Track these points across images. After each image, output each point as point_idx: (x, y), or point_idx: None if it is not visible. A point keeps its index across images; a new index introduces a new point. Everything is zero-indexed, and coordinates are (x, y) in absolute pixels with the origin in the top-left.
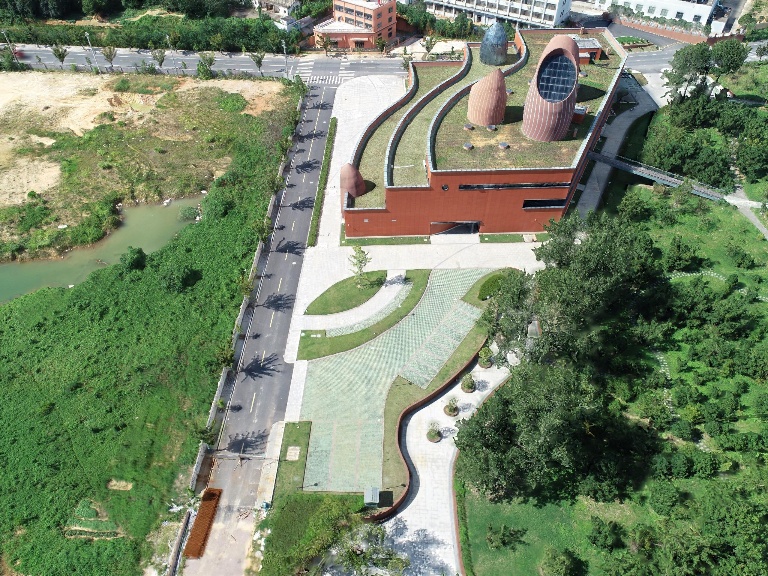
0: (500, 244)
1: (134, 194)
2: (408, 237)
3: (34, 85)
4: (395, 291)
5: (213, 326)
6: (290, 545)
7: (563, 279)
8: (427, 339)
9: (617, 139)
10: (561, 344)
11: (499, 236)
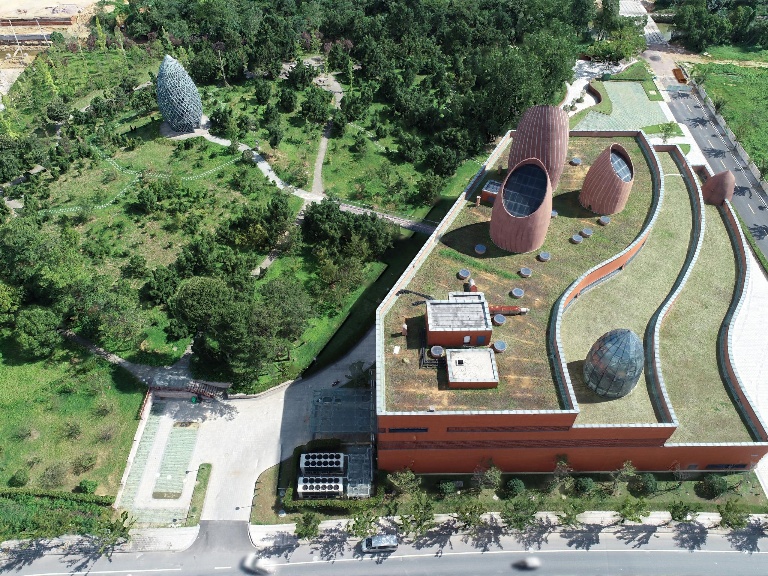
0: None
1: None
2: None
3: None
4: None
5: None
6: None
7: None
8: None
9: None
10: None
11: None
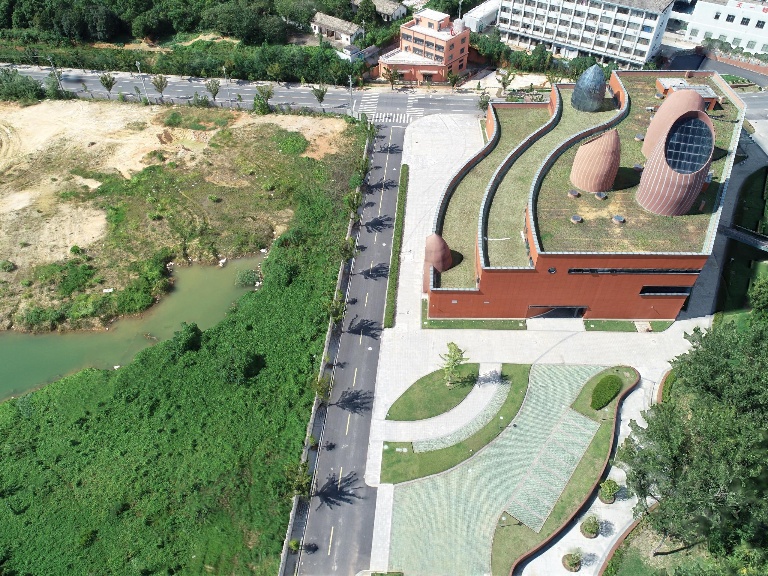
0: (609, 333)
1: (186, 251)
2: (500, 320)
3: (79, 116)
4: (491, 392)
5: (280, 431)
6: None
7: (737, 428)
8: (534, 461)
9: (729, 200)
10: (724, 502)
11: (607, 323)
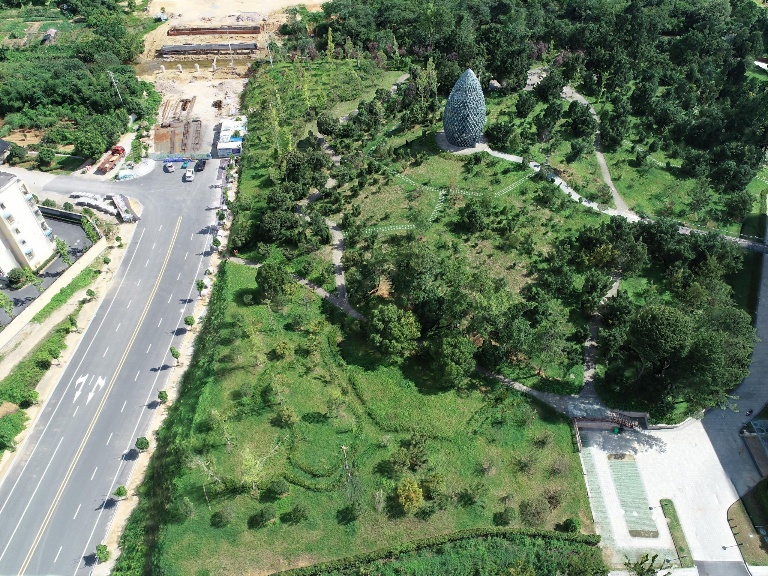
0: None
1: None
2: None
3: None
4: None
5: None
6: None
7: None
8: None
9: (762, 341)
10: None
11: None
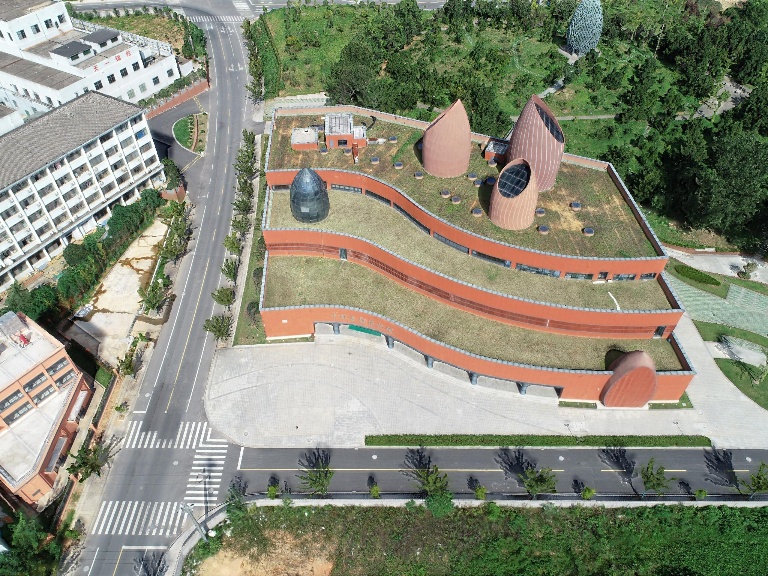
0: None
1: None
2: None
3: None
4: (744, 350)
5: None
6: None
7: None
8: None
9: None
10: None
11: None
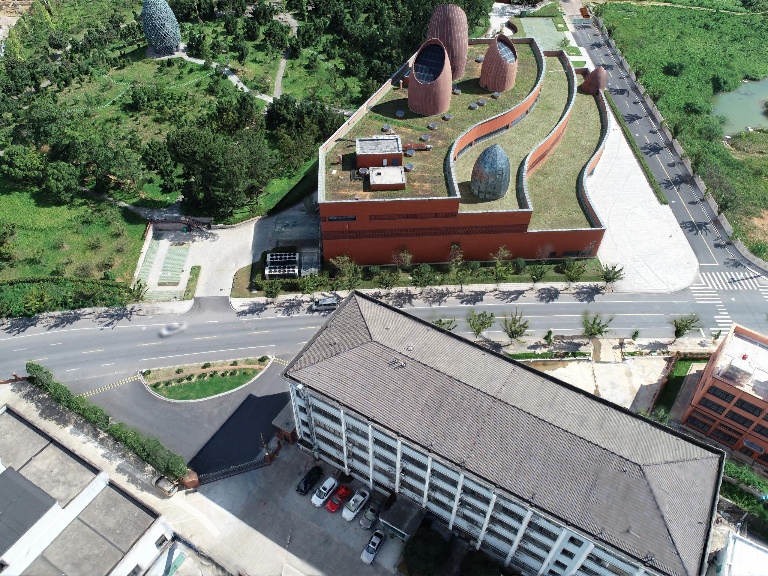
0: None
1: None
2: None
3: None
4: None
5: None
6: (549, 8)
7: None
8: None
9: None
10: None
11: None
